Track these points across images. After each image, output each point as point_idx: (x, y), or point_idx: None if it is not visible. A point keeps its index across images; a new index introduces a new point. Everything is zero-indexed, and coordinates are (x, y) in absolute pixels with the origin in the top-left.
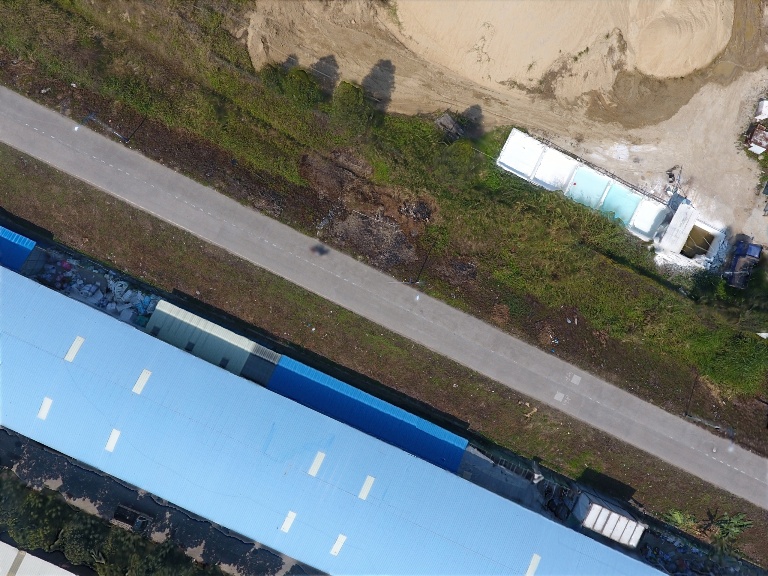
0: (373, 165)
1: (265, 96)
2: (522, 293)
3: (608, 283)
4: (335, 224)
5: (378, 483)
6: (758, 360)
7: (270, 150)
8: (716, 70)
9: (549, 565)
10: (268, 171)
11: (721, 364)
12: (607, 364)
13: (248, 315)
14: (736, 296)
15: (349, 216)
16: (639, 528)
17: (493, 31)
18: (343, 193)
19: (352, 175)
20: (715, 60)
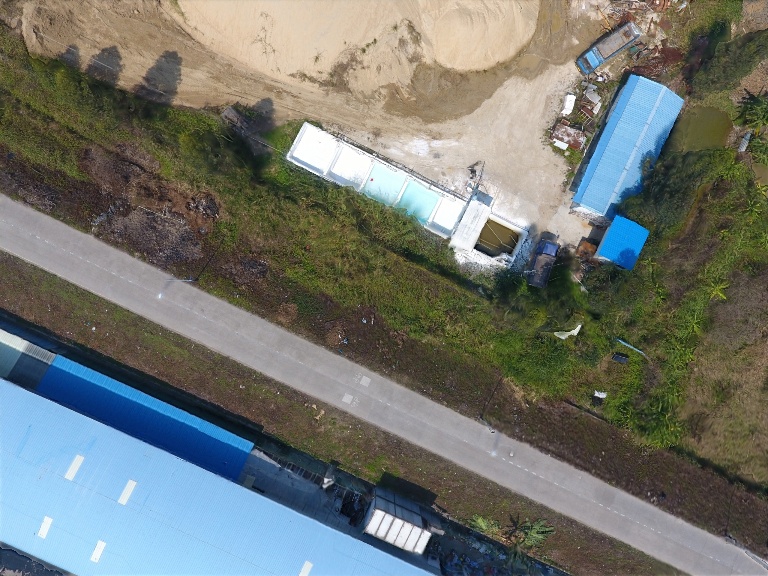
0: (159, 159)
1: (43, 88)
2: (315, 292)
3: (407, 282)
4: (114, 220)
5: (140, 487)
6: (555, 362)
7: (47, 143)
8: (521, 63)
9: (321, 573)
10: (44, 165)
11: (524, 366)
12: (400, 365)
13: (28, 314)
14: (540, 296)
15: (133, 212)
16: (425, 534)
17: (271, 21)
18: (128, 188)
19: (139, 170)
20: (520, 53)
